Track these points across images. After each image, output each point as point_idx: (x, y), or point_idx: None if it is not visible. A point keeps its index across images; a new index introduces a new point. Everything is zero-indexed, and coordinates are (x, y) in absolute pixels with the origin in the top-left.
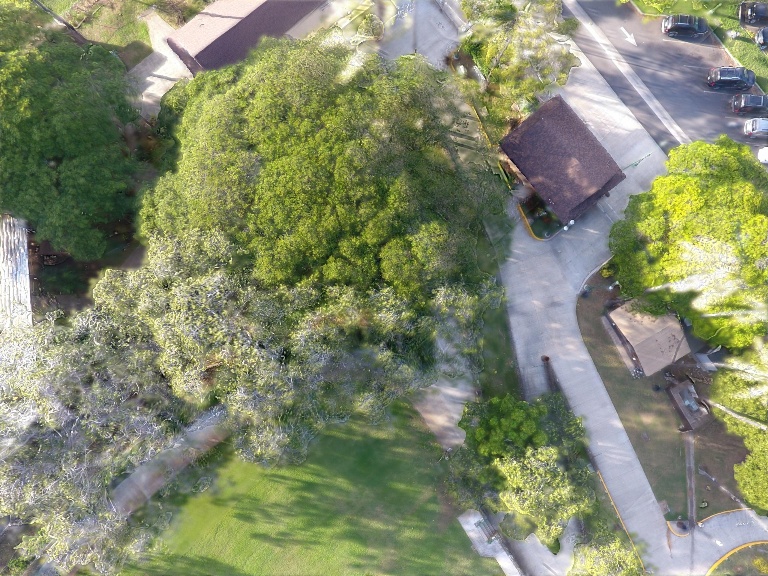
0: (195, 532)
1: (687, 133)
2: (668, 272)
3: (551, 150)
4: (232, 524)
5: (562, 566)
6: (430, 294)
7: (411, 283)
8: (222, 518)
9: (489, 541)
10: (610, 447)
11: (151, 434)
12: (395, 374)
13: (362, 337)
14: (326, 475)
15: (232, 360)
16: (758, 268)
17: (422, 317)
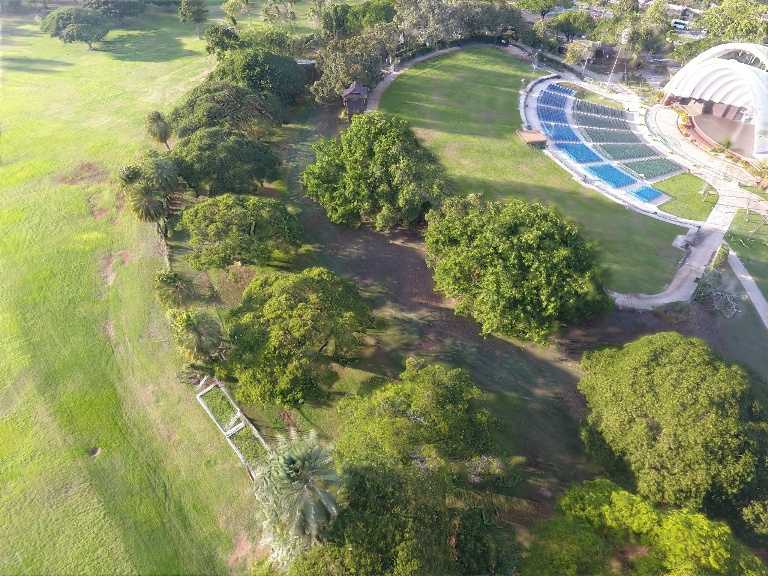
0: (452, 60)
1: (560, 36)
2: (560, 19)
3: (523, 26)
4: (462, 60)
5: (568, 75)
6: (505, 4)
7: (500, 3)
8: (459, 59)
9: (542, 68)
10: (571, 65)
11: (453, 5)
12: (502, 10)
13: (492, 6)
14: (486, 56)
15: (467, 0)
16: (580, 13)
17: (504, 6)
